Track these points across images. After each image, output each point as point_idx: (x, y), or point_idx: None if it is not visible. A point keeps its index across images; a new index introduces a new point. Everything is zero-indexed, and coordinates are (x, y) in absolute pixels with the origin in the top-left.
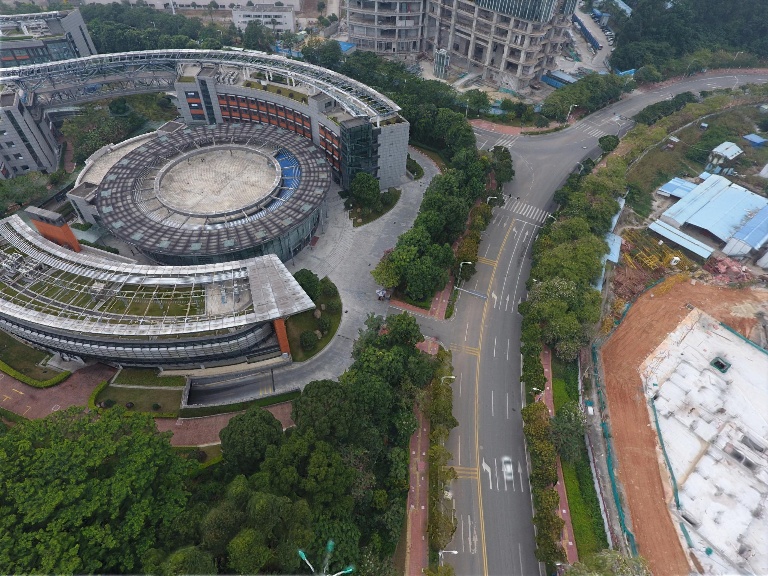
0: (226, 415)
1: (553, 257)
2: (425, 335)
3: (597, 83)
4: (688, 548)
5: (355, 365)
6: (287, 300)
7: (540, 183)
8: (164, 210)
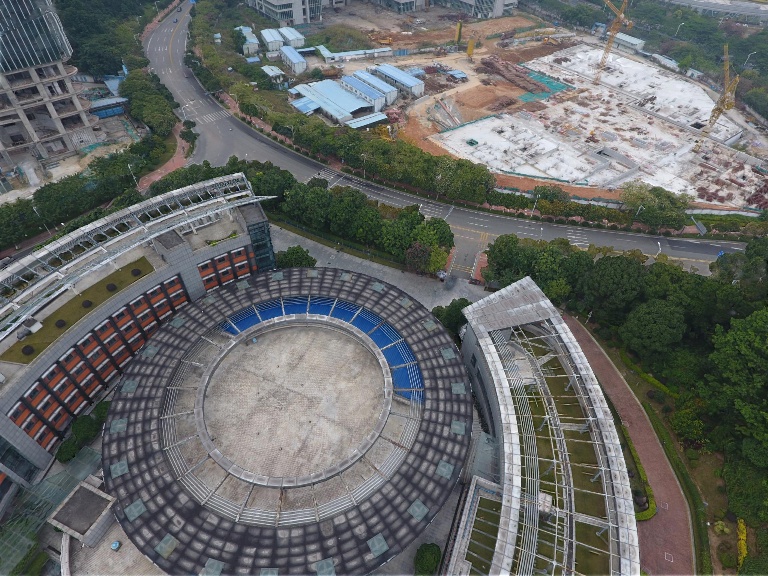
0: (603, 387)
1: (412, 165)
2: (475, 259)
3: (146, 86)
4: (588, 186)
5: (543, 283)
6: (527, 295)
7: (279, 164)
8: (353, 470)
